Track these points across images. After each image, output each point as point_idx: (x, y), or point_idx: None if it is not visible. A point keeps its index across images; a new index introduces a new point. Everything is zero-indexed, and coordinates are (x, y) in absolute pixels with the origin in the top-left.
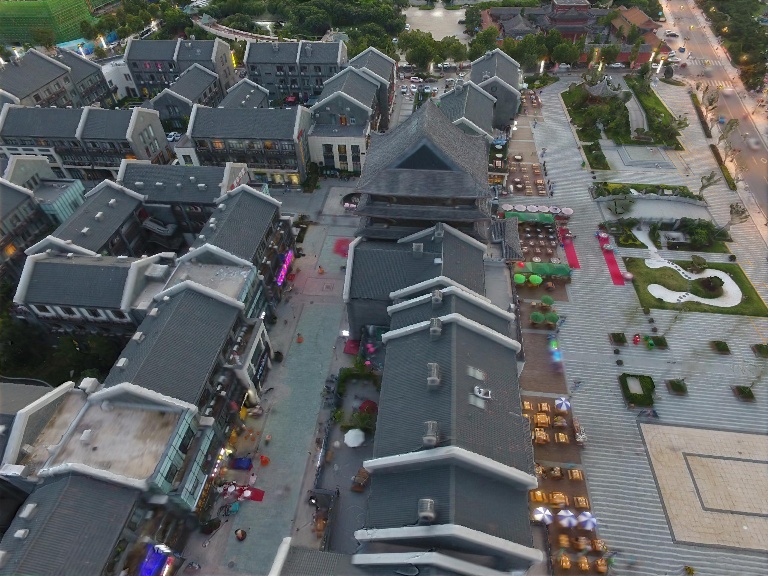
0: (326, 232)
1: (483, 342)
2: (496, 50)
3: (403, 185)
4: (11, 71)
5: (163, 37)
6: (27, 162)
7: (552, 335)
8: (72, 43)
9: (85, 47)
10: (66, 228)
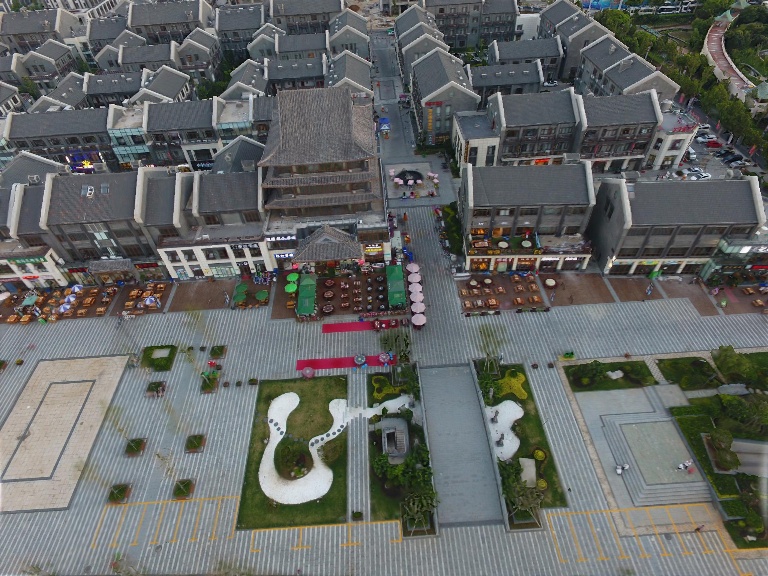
0: None
1: (133, 193)
2: (750, 177)
3: (277, 126)
4: None
5: (677, 20)
6: (353, 34)
7: (228, 304)
8: None
9: (600, 2)
10: (278, 61)
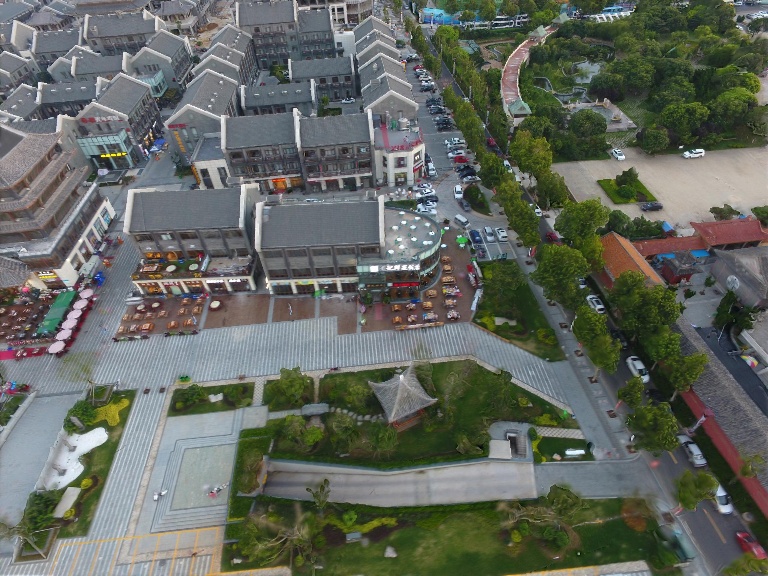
0: (109, 194)
1: None
2: None
3: None
4: (263, 7)
5: (509, 34)
6: (153, 55)
7: None
8: (435, 11)
9: (442, 18)
10: (54, 85)
